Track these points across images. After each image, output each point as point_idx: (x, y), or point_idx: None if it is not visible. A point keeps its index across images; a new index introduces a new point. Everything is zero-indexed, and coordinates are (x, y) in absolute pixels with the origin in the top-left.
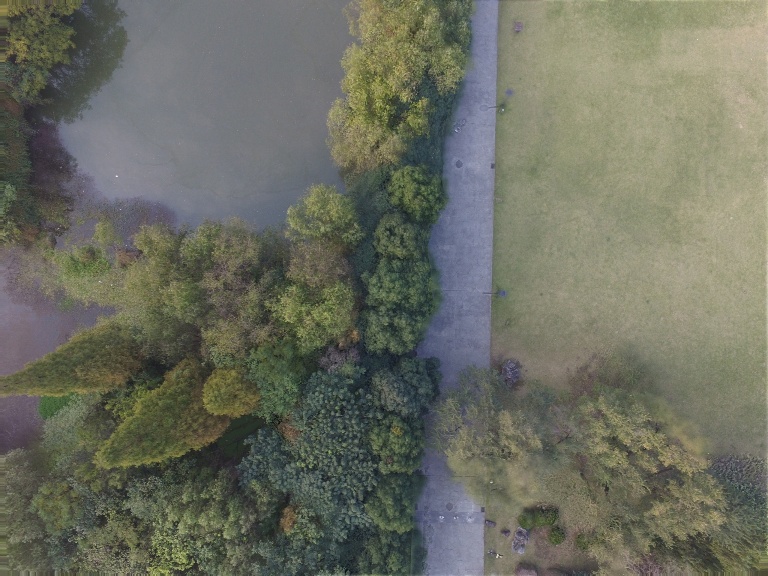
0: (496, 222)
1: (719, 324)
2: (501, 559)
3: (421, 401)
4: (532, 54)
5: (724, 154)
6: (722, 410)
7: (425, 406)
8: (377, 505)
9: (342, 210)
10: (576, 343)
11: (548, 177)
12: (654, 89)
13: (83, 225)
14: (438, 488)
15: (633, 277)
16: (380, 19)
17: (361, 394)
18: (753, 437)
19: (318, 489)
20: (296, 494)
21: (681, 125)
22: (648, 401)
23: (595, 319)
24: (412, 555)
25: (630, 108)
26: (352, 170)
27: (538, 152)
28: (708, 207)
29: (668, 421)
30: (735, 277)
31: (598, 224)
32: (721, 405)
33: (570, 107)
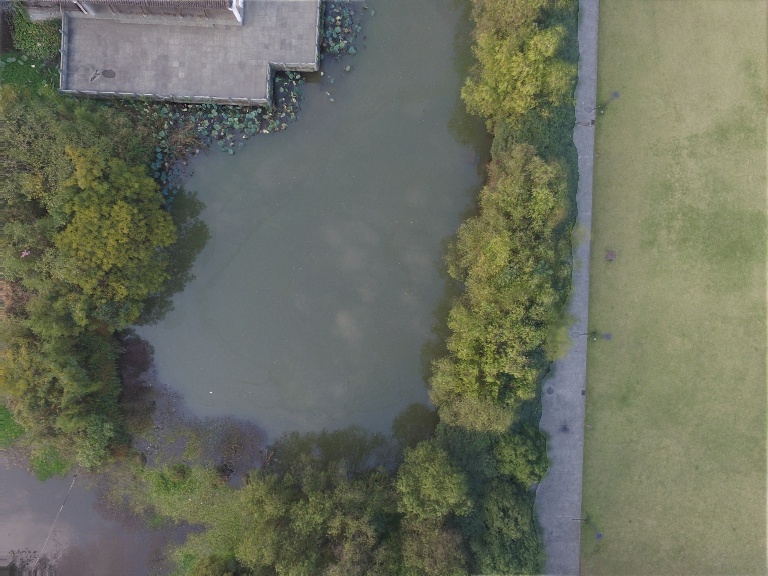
0: (586, 449)
1: None
2: None
3: None
4: (625, 284)
5: None
6: None
7: None
8: None
9: (457, 491)
10: (663, 570)
11: (638, 405)
12: (745, 320)
13: (173, 443)
14: None
15: (720, 505)
16: (494, 297)
17: None
18: None
19: None
20: None
21: None
22: None
23: (682, 547)
24: None
25: (721, 339)
26: (462, 441)
27: (629, 380)
28: None
29: None
30: None
31: (687, 453)
32: None
33: (661, 337)
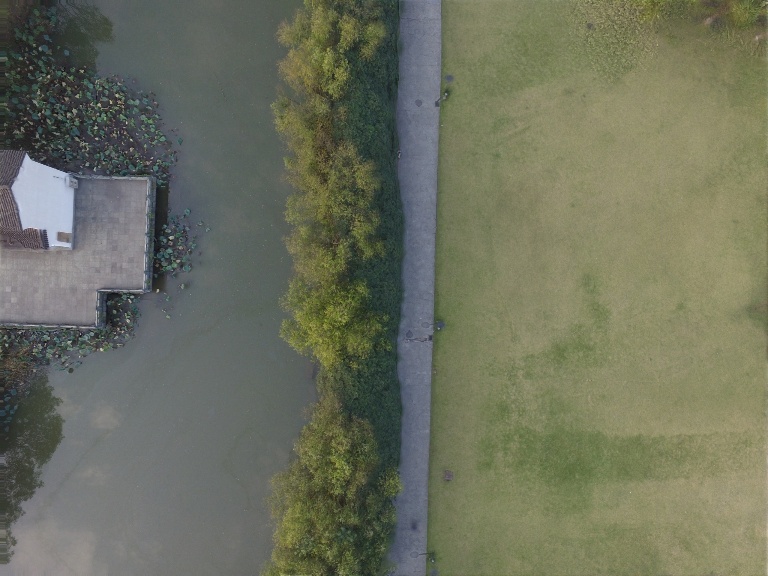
0: None
1: None
2: None
3: None
4: (462, 505)
5: None
6: None
7: None
8: None
9: None
10: None
11: None
12: (586, 541)
13: None
14: None
15: None
16: (292, 568)
17: None
18: None
19: None
20: None
21: None
22: None
23: None
24: None
25: (562, 560)
26: None
27: None
28: None
29: None
30: None
31: None
32: None
33: (501, 558)
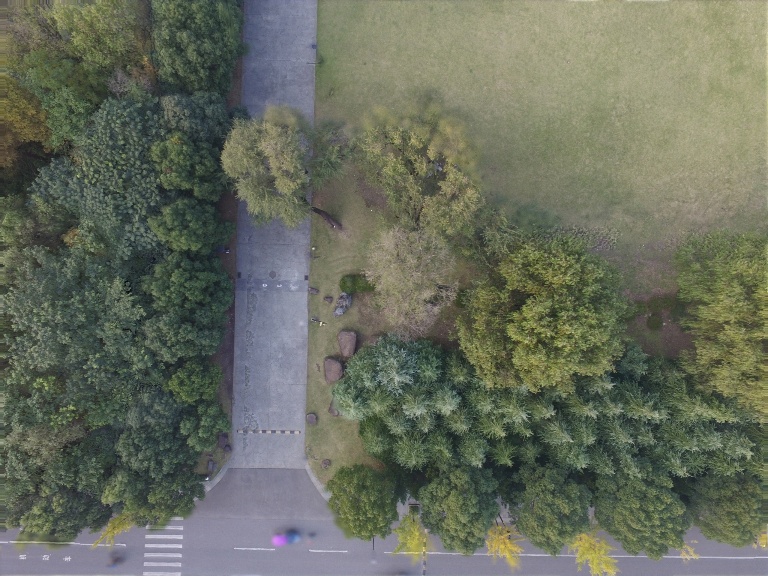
0: None
1: (543, 94)
2: (324, 327)
3: (210, 124)
4: None
5: None
6: (547, 180)
7: (216, 132)
8: (159, 219)
9: None
10: (399, 112)
11: None
12: None
13: None
14: (261, 256)
15: (456, 46)
16: None
17: (150, 117)
18: (578, 208)
19: (101, 204)
20: (82, 214)
21: None
22: (472, 171)
23: (418, 87)
24: (236, 324)
25: None
26: None
27: None
28: None
29: (493, 191)
30: (558, 47)
31: None
32: (545, 175)
33: None
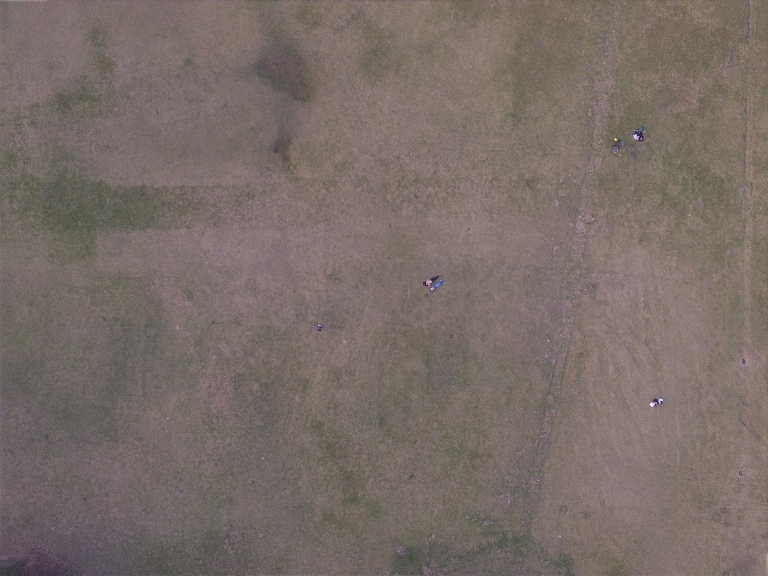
0: None
1: (156, 522)
2: None
3: None
4: None
5: (161, 355)
6: None
7: None
8: None
9: None
10: (13, 538)
11: None
12: (92, 290)
13: None
14: None
15: (70, 475)
16: None
17: None
18: None
19: None
20: None
21: (119, 326)
22: None
23: (31, 515)
24: None
25: (68, 308)
26: None
27: None
28: (145, 407)
29: None
30: (171, 476)
31: (37, 422)
32: None
33: (11, 306)
